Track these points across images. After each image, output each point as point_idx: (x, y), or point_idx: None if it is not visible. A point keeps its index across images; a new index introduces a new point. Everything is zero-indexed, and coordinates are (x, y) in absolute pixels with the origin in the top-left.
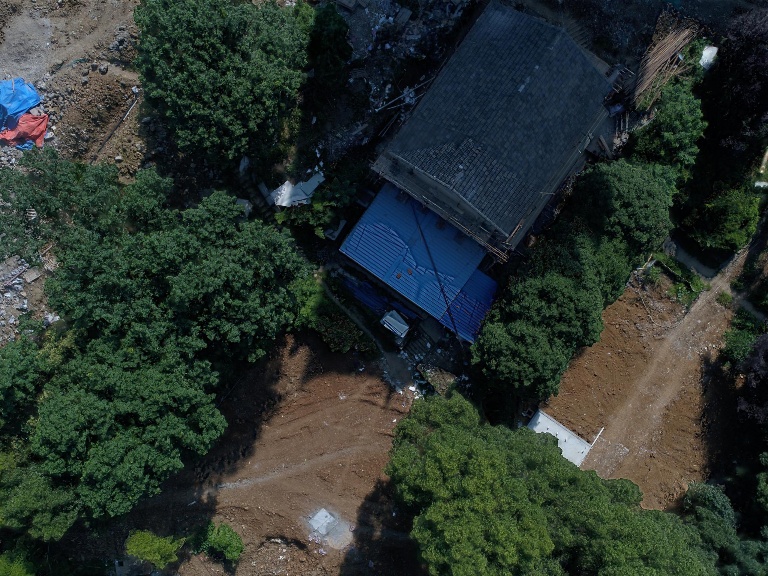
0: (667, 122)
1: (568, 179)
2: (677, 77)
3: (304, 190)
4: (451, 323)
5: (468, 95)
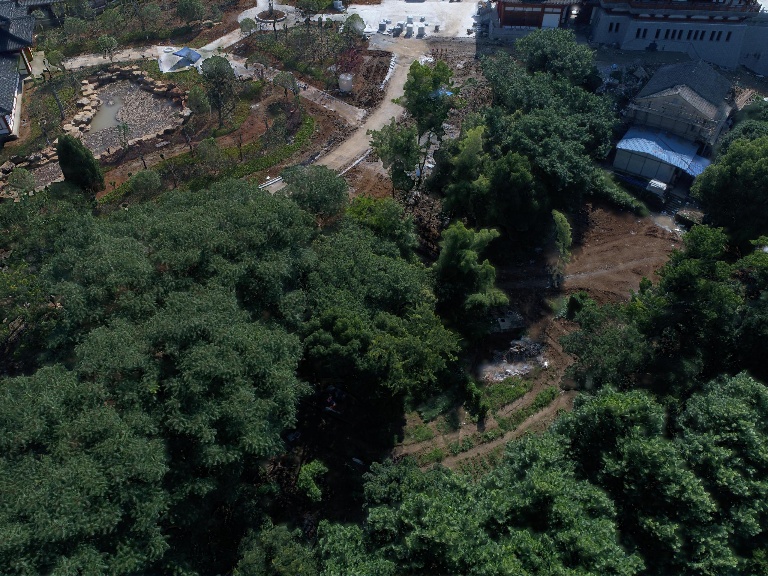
0: None
1: None
2: None
3: None
4: (693, 173)
5: None
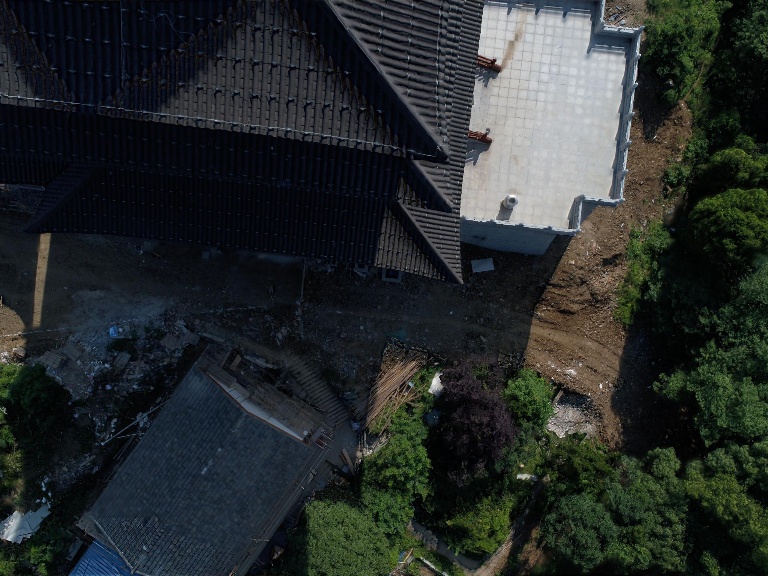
0: (390, 458)
1: (312, 492)
2: (408, 403)
3: (30, 523)
4: None
5: (161, 466)
